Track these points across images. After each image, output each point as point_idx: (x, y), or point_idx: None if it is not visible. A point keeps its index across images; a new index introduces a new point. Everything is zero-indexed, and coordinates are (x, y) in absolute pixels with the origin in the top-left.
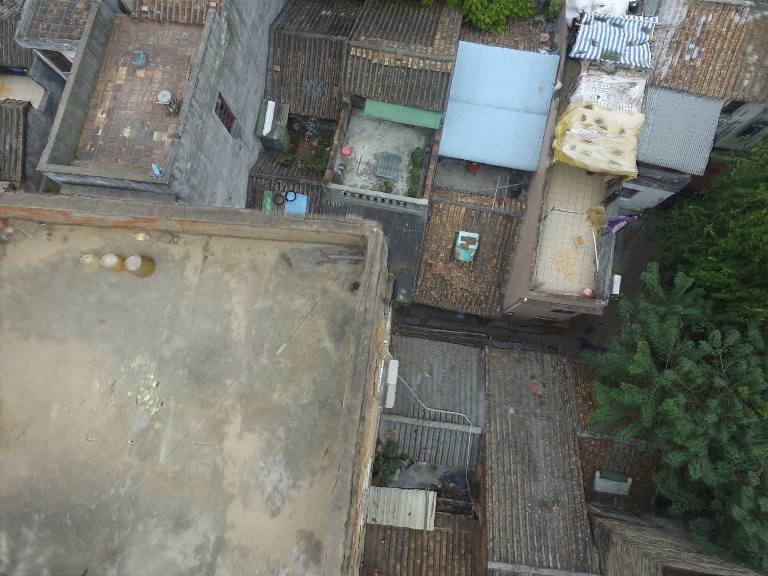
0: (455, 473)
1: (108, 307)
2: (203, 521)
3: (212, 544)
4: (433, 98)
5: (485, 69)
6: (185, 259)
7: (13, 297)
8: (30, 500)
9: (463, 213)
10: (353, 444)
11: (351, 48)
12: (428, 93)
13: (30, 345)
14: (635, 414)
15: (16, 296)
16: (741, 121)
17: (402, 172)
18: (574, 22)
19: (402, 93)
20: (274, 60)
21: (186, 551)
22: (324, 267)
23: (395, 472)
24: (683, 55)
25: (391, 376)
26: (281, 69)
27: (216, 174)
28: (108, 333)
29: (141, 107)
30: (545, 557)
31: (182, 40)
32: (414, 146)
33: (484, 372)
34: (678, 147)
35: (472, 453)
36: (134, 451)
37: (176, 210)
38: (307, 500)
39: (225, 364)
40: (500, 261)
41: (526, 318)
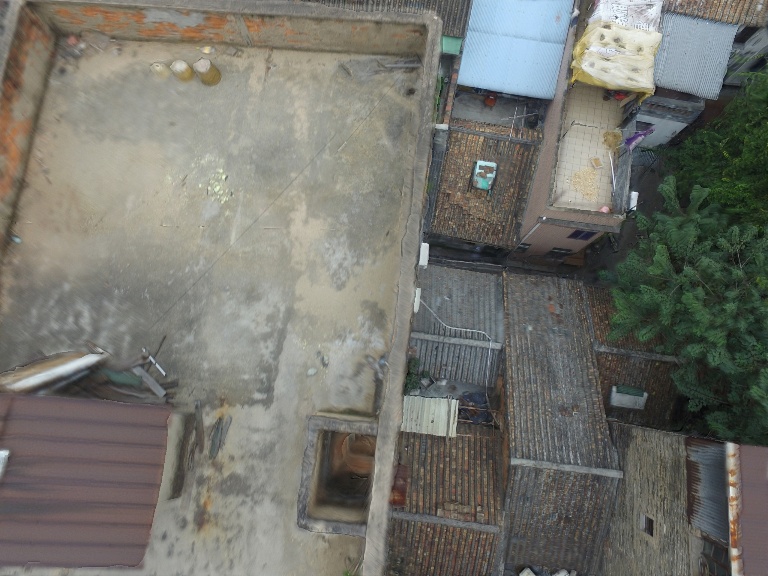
0: (474, 393)
1: (177, 112)
2: (273, 294)
3: (282, 314)
4: (454, 24)
5: None
6: (249, 70)
7: (87, 104)
8: (110, 277)
9: (481, 142)
10: (420, 200)
11: None
12: (449, 19)
13: (104, 145)
14: (654, 316)
15: (90, 103)
16: (753, 51)
17: None
18: None
19: None
20: None
21: (258, 320)
22: (381, 76)
23: (417, 386)
24: None
25: (422, 258)
26: None
27: None
28: (178, 134)
29: None
30: (566, 455)
31: None
32: None
33: (502, 295)
34: (693, 72)
35: (492, 369)
36: (206, 235)
37: (247, 4)
38: (371, 275)
39: (290, 160)
40: (517, 190)
41: (541, 252)
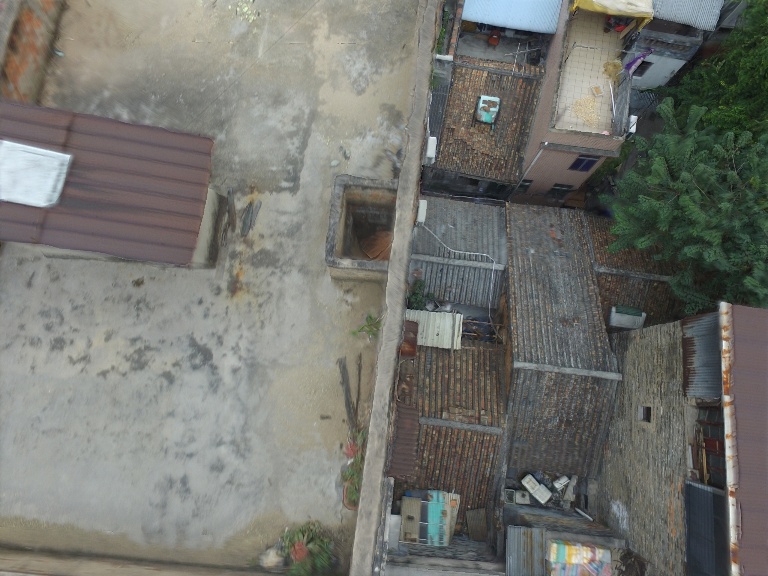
0: (477, 317)
1: None
2: (298, 98)
3: (307, 115)
4: None
5: None
6: None
7: None
8: (147, 85)
9: (485, 77)
10: None
11: None
12: None
13: None
14: (652, 225)
15: None
16: None
17: None
18: None
19: None
20: None
21: (285, 120)
22: None
23: (422, 306)
24: None
25: (430, 150)
26: None
27: None
28: None
29: None
30: (567, 360)
31: None
32: None
33: (505, 222)
34: (691, 4)
35: (495, 290)
36: (236, 49)
37: None
38: (389, 82)
39: None
40: (520, 125)
41: (543, 190)
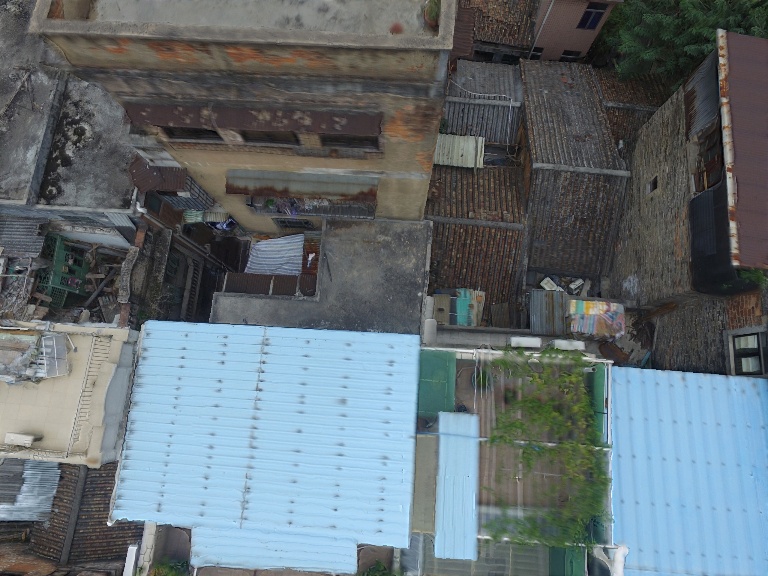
0: (496, 159)
1: None
2: None
3: None
4: None
5: None
6: None
7: None
8: None
9: None
10: None
11: None
12: None
13: None
14: (655, 40)
15: None
16: None
17: None
18: None
19: None
20: None
21: None
22: None
23: None
24: None
25: None
26: None
27: None
28: None
29: None
30: (580, 162)
31: None
32: None
33: (520, 73)
34: None
35: (512, 127)
36: None
37: None
38: None
39: None
40: None
41: None
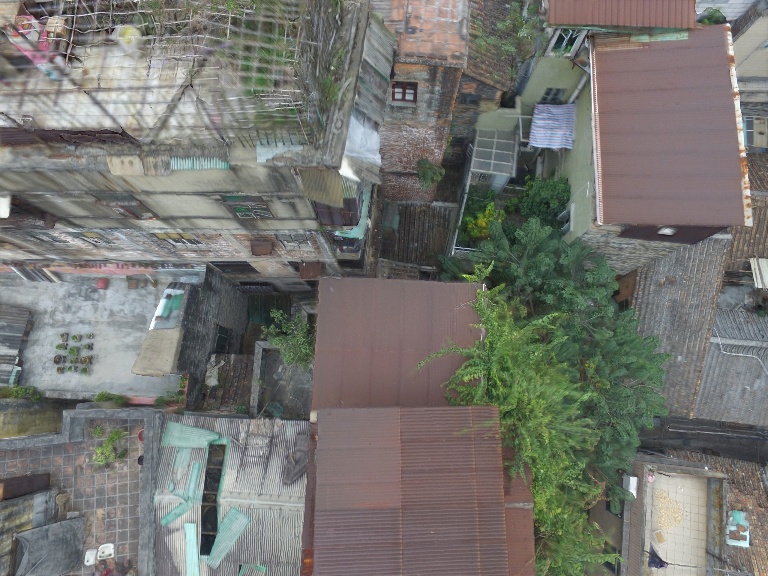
0: None
1: None
2: None
3: None
4: None
5: None
6: None
7: None
8: None
9: (756, 570)
10: None
11: None
12: None
13: None
14: None
15: None
16: None
17: None
18: None
19: None
20: None
21: None
22: None
23: None
24: None
25: None
26: None
27: None
28: None
29: None
30: None
31: None
32: None
33: None
34: None
35: None
36: None
37: None
38: None
39: None
40: None
41: None
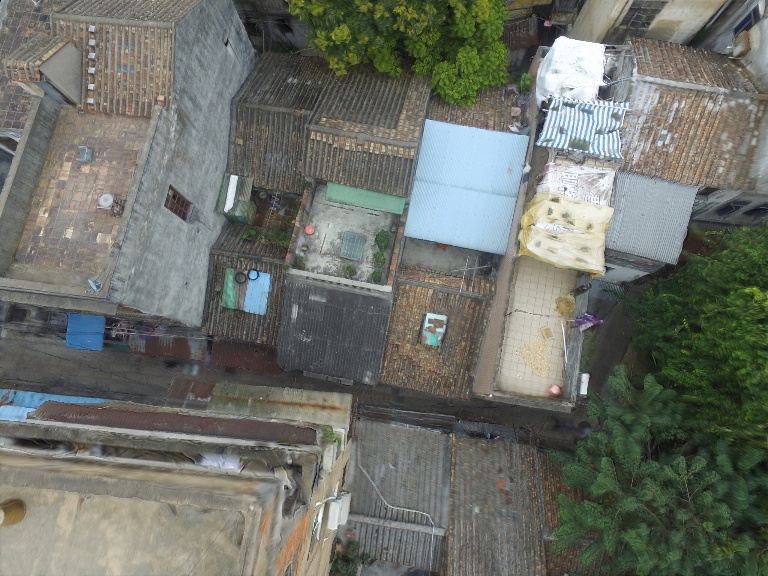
0: (420, 570)
1: None
2: None
3: None
4: (396, 183)
5: (452, 148)
6: (59, 502)
7: None
8: None
9: (430, 295)
10: None
11: (311, 132)
12: (391, 178)
13: None
14: (599, 534)
15: None
16: (718, 202)
17: (367, 252)
18: (543, 104)
19: (364, 177)
20: (237, 133)
21: None
22: (211, 514)
23: (354, 575)
24: (655, 141)
25: (332, 521)
26: (244, 142)
27: (168, 267)
28: None
29: (85, 206)
30: None
31: (130, 133)
32: (380, 224)
33: (450, 464)
34: (651, 234)
35: (435, 554)
36: None
37: (33, 477)
38: None
39: None
40: (469, 344)
41: None
